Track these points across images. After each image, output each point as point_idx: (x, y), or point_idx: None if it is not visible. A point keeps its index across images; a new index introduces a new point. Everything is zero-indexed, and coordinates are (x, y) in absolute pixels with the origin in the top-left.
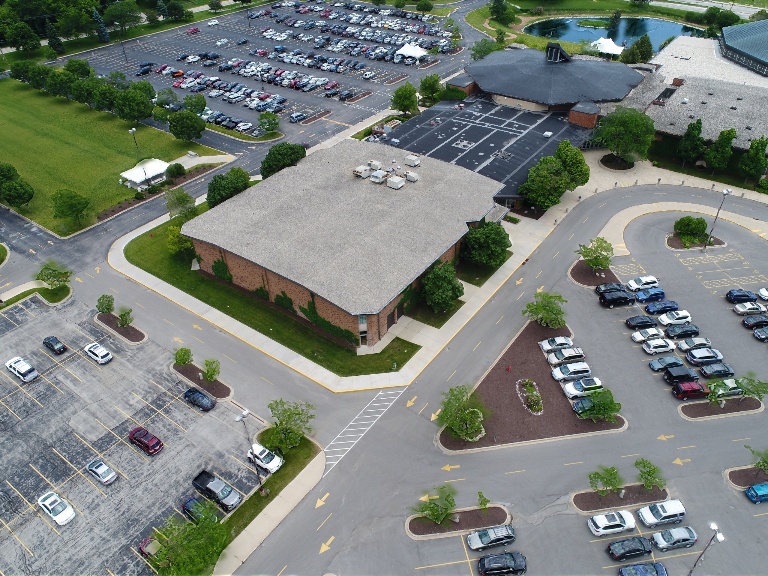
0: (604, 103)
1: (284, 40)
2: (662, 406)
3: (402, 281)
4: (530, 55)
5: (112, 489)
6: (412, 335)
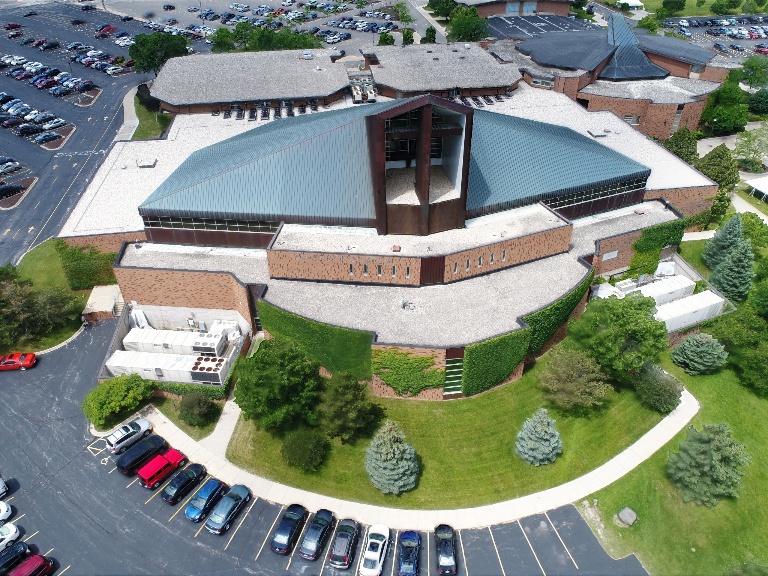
0: None
1: None
2: None
3: None
4: (659, 44)
5: None
6: None
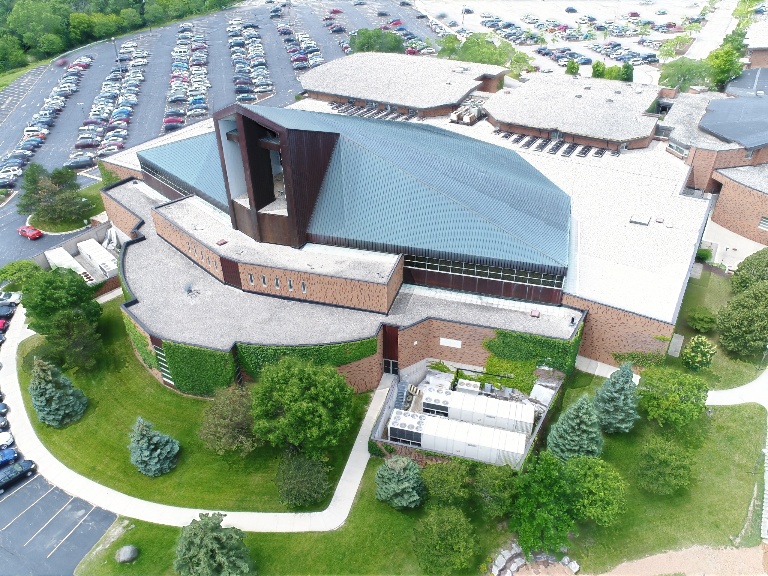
0: None
1: None
2: None
3: None
4: None
5: None
6: None
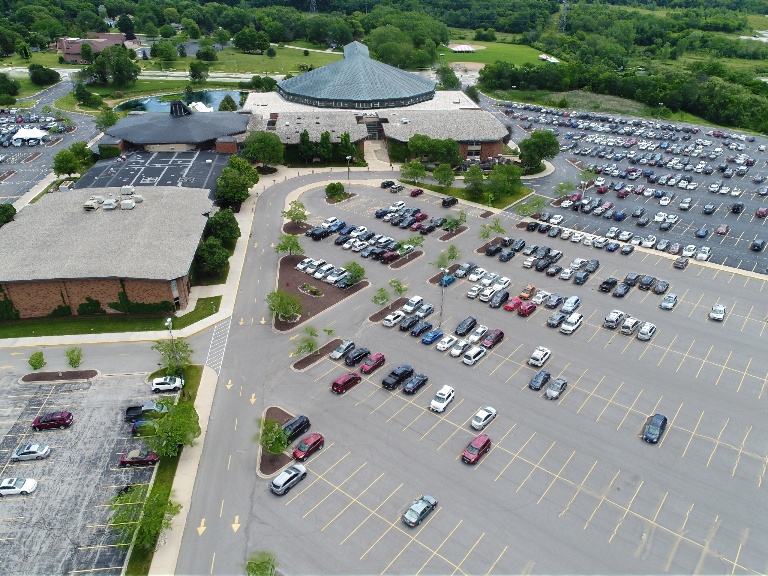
0: (235, 136)
1: None
2: (381, 269)
3: (188, 254)
4: (156, 115)
5: (53, 457)
6: (209, 293)
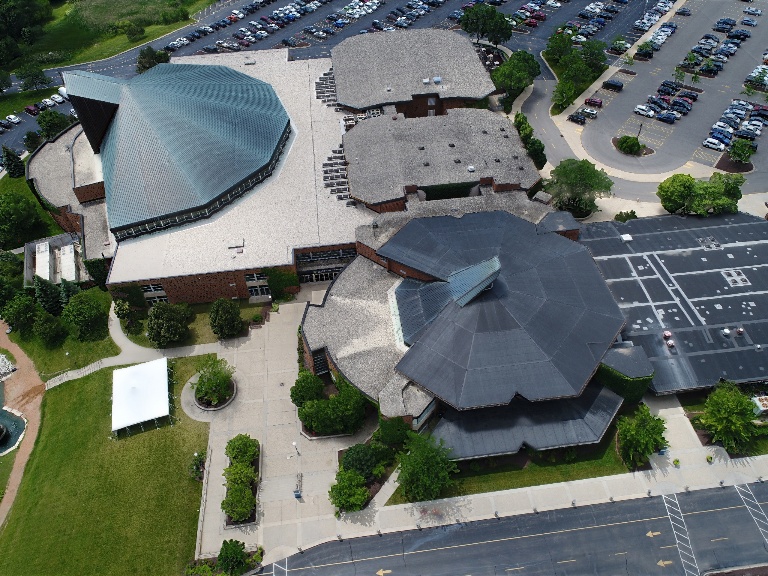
0: None
1: None
2: None
3: None
4: (468, 331)
5: None
6: None
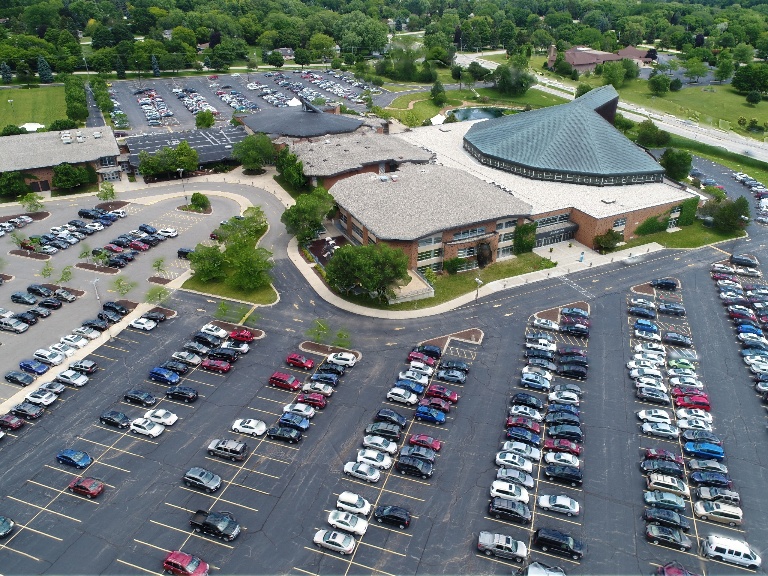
0: (291, 137)
1: (253, 90)
2: (10, 247)
3: None
4: None
5: None
6: None
